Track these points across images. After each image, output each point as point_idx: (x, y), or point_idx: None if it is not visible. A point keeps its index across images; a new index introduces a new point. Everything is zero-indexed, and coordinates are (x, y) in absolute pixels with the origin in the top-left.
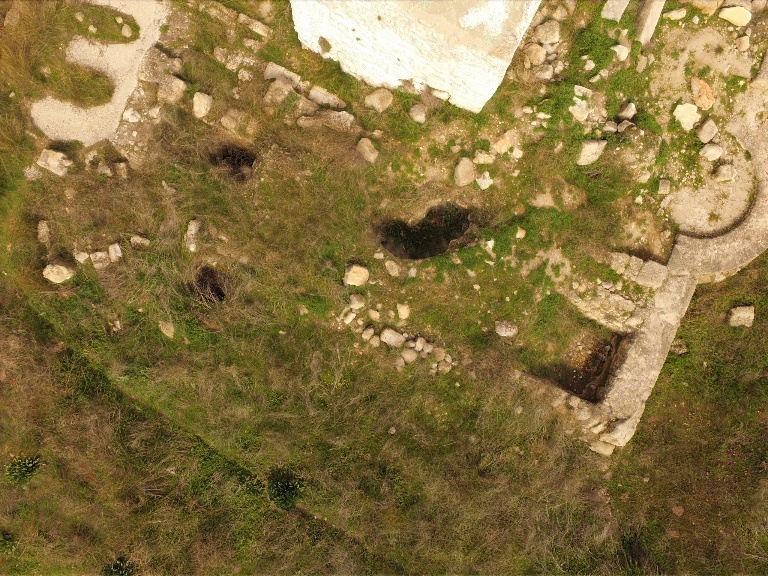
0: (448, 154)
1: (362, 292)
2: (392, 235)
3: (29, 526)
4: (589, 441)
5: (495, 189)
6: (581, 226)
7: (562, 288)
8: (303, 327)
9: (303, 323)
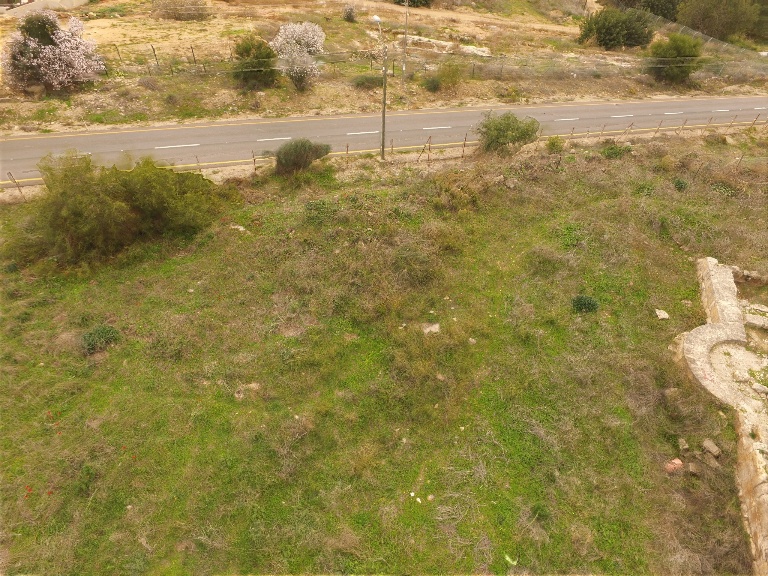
0: None
1: None
2: None
3: None
4: None
5: None
6: None
7: None
8: None
9: None
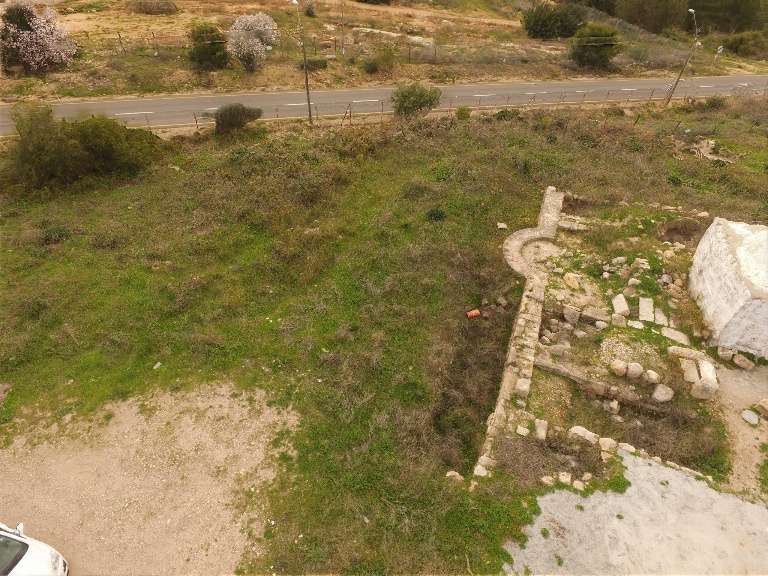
0: None
1: None
2: None
3: (764, 176)
4: None
5: None
6: None
7: None
8: None
9: None
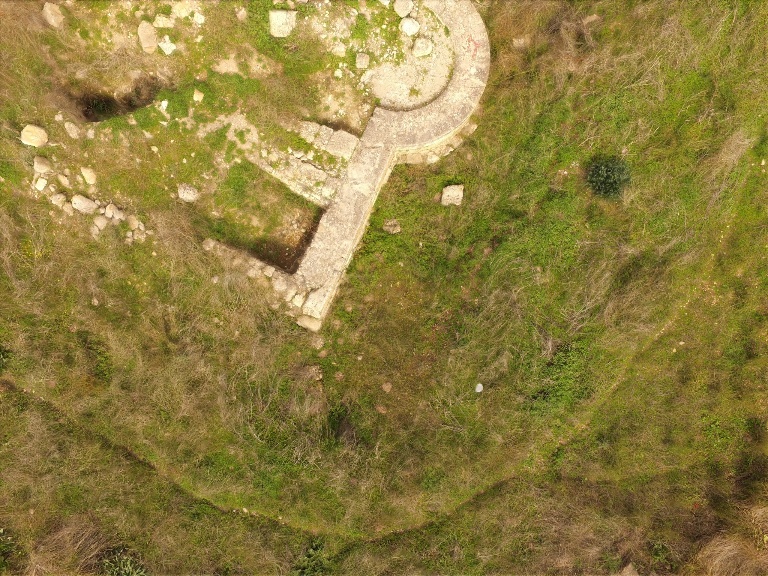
0: (133, 19)
1: (46, 155)
2: (105, 112)
3: None
4: (295, 316)
5: (179, 54)
6: (269, 94)
7: (253, 157)
8: (1, 196)
9: (1, 192)
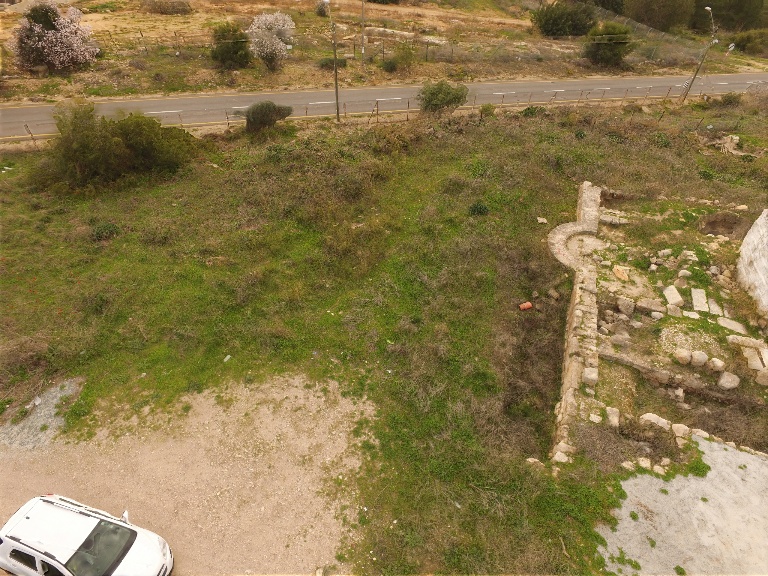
0: None
1: None
2: None
3: None
4: None
5: None
6: None
7: None
8: None
9: None
